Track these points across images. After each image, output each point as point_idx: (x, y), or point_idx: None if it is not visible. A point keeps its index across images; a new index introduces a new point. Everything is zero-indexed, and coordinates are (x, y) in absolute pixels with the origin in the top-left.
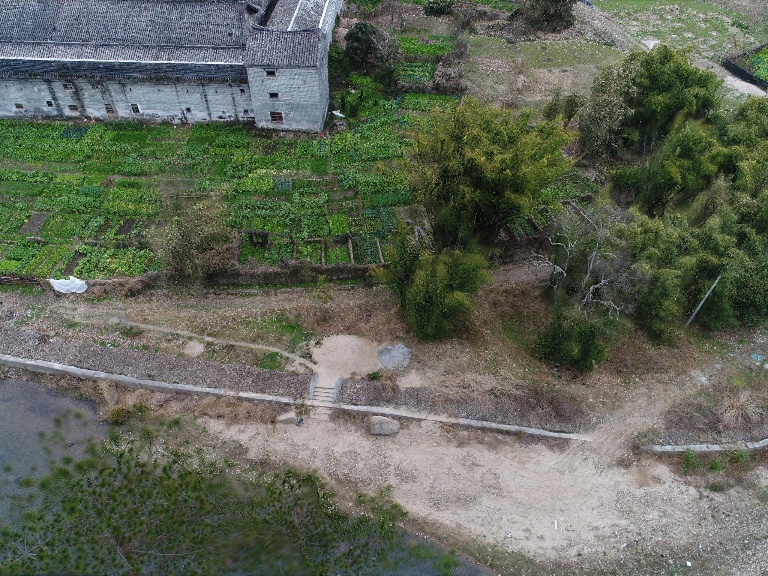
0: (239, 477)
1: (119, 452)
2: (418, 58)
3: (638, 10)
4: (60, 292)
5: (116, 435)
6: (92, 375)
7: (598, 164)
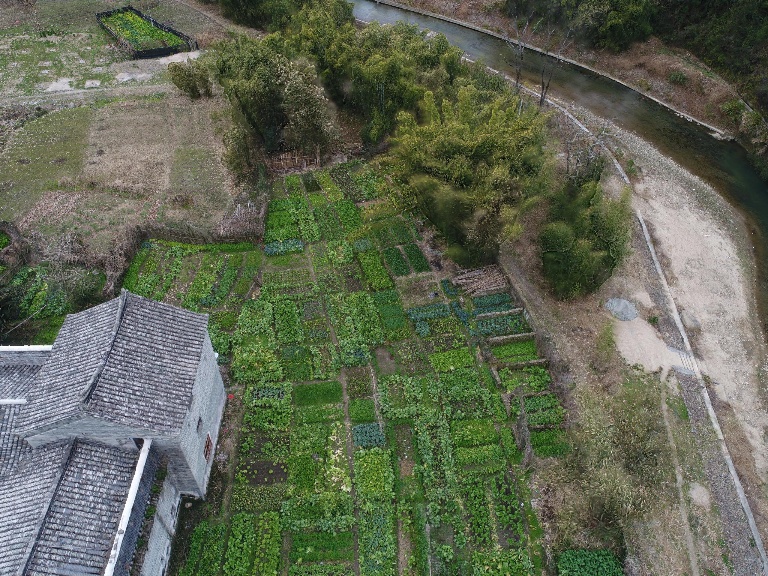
0: None
1: None
2: (1, 281)
3: None
4: None
5: None
6: None
7: (331, 149)
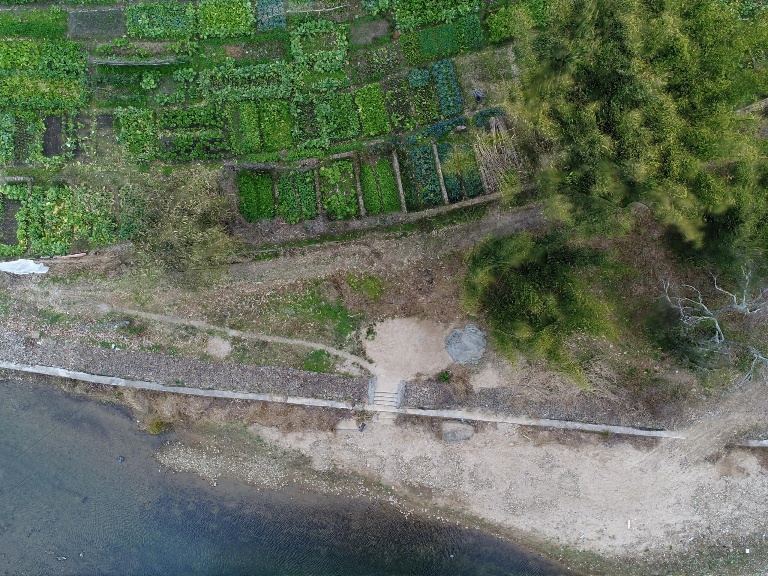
0: (309, 487)
1: (176, 466)
2: None
3: None
4: (15, 274)
5: (165, 446)
6: (109, 383)
7: None
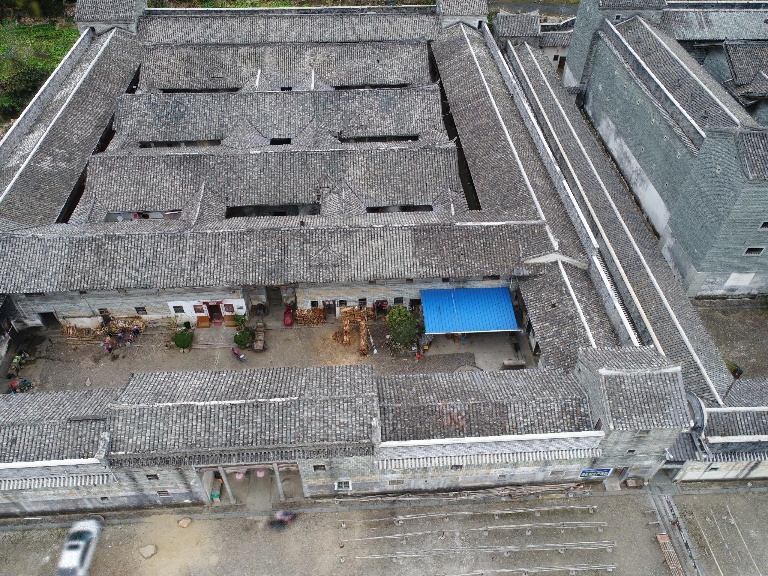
0: None
1: None
2: None
3: None
4: None
5: None
6: None
7: None
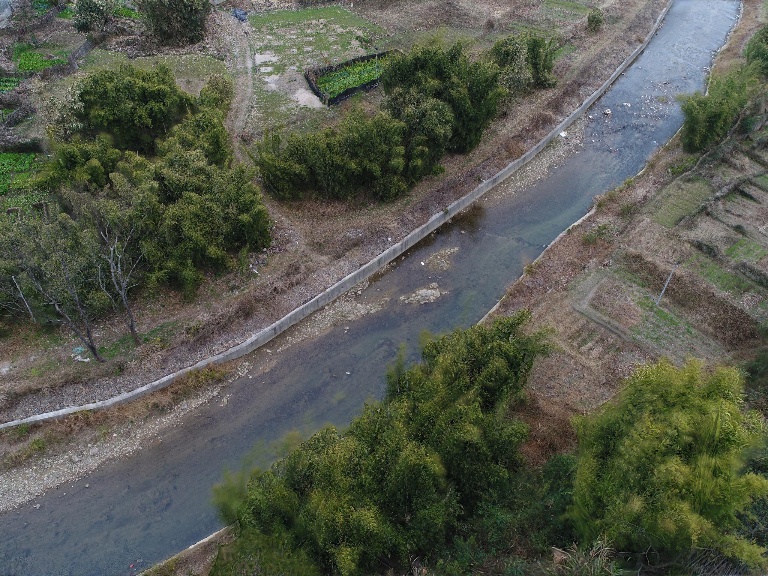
0: None
1: None
2: (18, 74)
3: (285, 25)
4: None
5: None
6: None
7: None
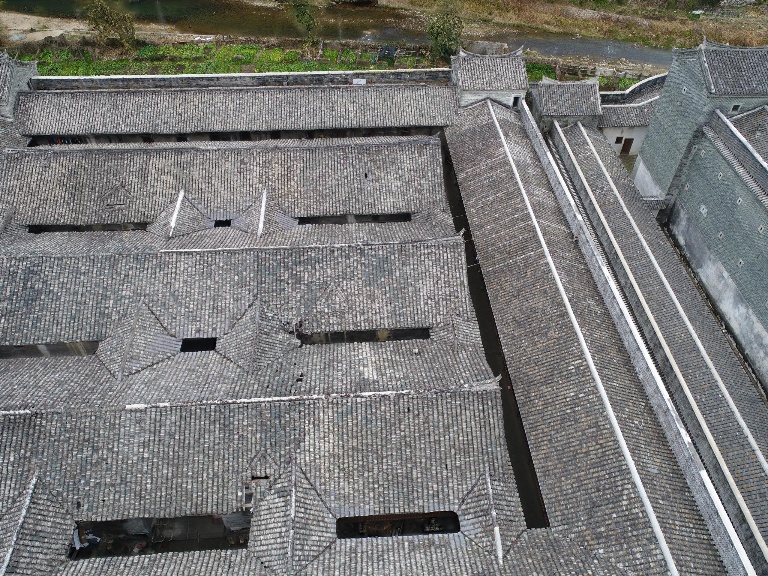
0: None
1: None
2: None
3: None
4: None
5: None
6: None
7: None
